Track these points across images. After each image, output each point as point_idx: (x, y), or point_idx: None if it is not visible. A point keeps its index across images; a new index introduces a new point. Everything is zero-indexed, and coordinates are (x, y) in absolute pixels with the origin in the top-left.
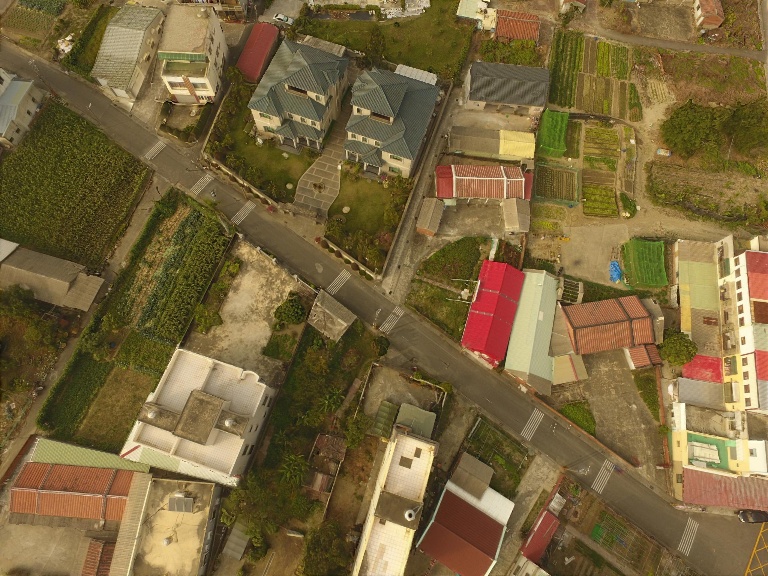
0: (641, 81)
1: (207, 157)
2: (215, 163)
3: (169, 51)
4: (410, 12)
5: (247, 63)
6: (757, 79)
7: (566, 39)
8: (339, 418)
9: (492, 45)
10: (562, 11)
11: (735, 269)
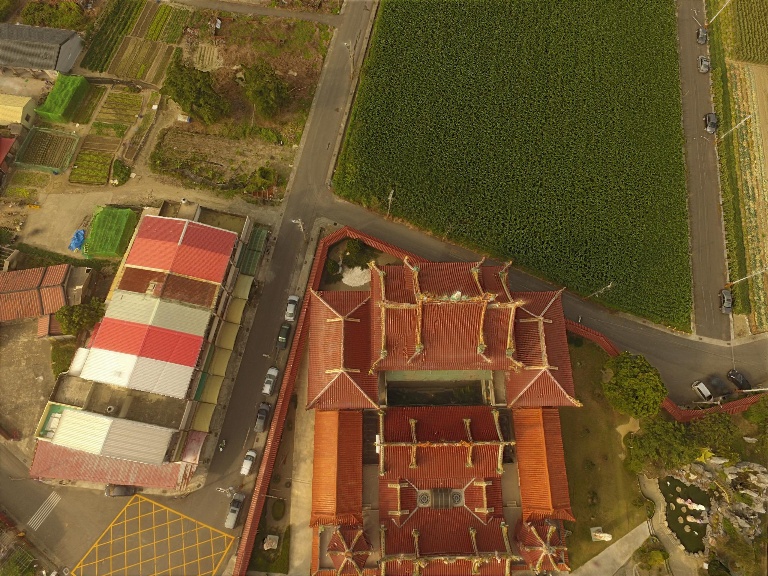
0: (190, 45)
1: None
2: None
3: None
4: None
5: None
6: (320, 44)
7: (125, 1)
8: None
9: (35, 7)
10: None
11: None
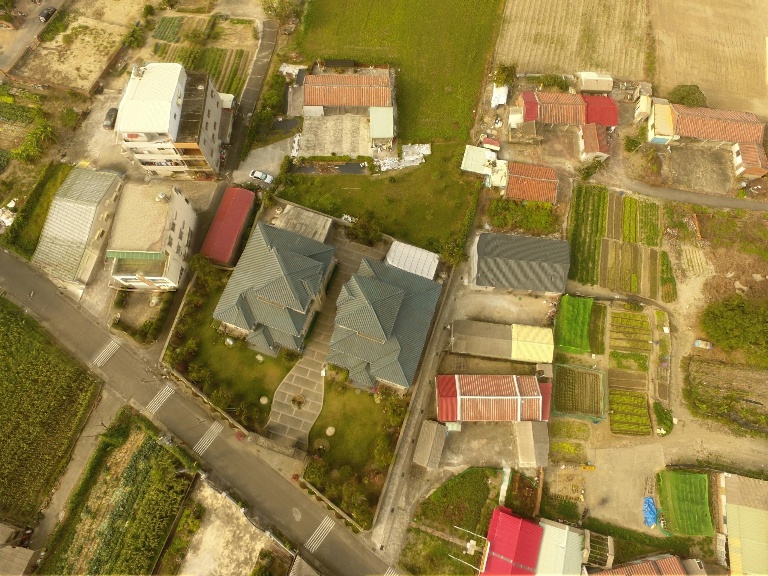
0: (674, 248)
1: (166, 369)
2: (175, 375)
3: (120, 250)
4: (408, 161)
5: (216, 243)
6: None
7: (587, 194)
8: None
9: (502, 206)
10: (582, 159)
11: None
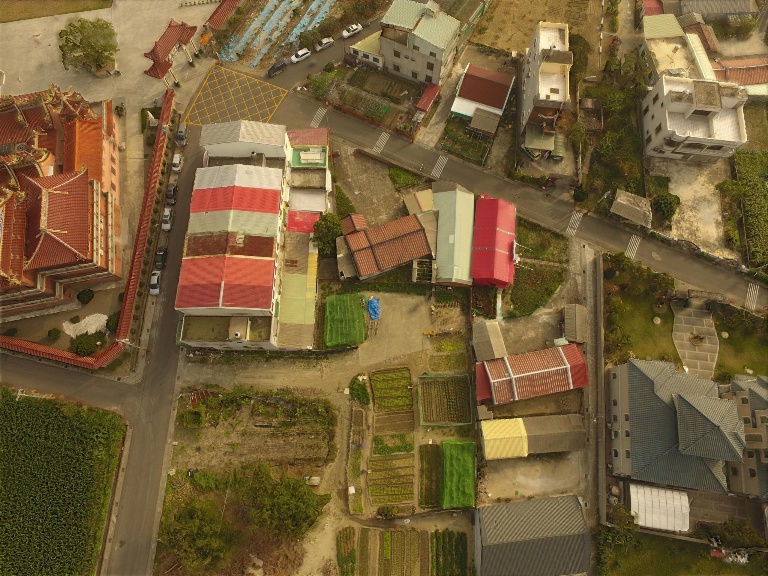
0: None
1: None
2: None
3: None
4: None
5: None
6: None
7: None
8: (590, 145)
9: None
10: None
11: (274, 300)
